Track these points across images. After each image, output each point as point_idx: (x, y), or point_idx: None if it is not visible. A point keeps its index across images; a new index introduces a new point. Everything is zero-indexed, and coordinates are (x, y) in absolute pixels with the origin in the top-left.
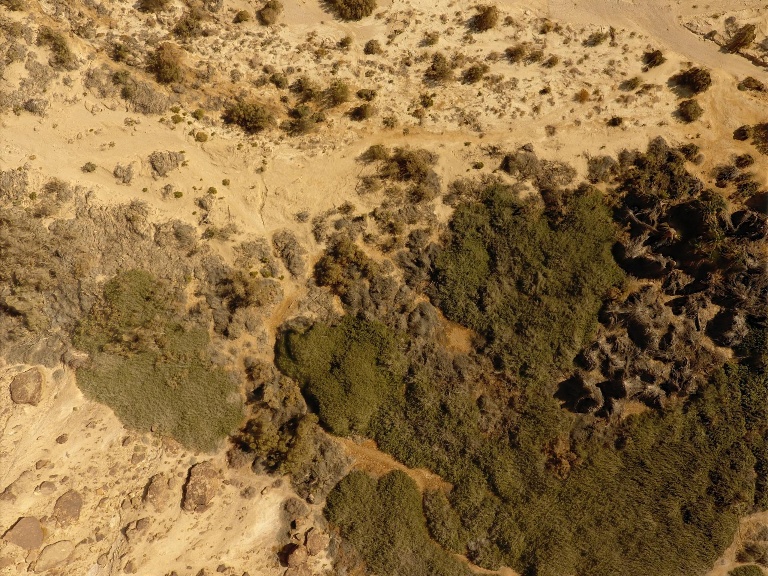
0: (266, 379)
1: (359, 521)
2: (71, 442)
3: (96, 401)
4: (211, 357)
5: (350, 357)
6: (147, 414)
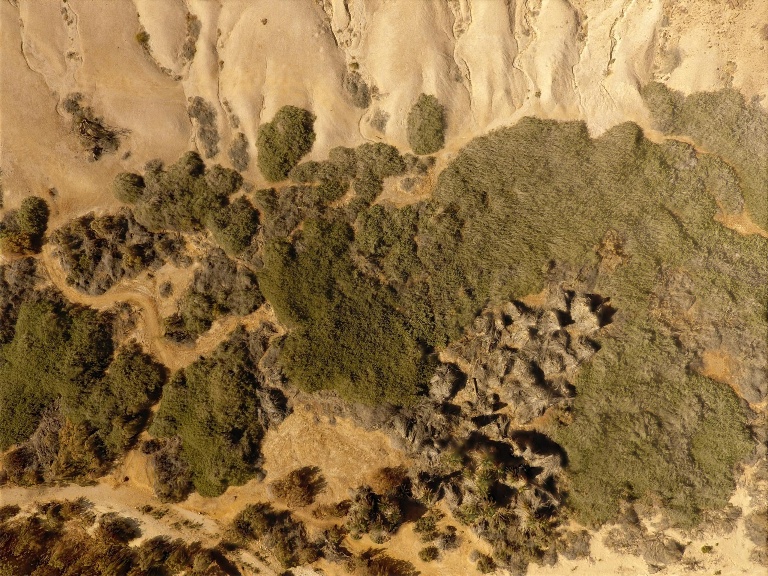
0: None
1: None
2: None
3: None
4: None
5: None
6: None
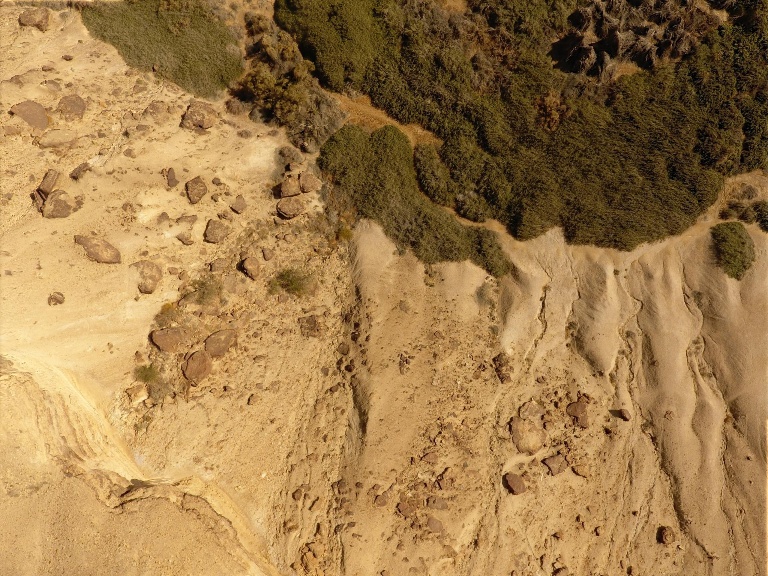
0: (265, 34)
1: (351, 167)
2: (76, 62)
3: (101, 40)
4: (212, 9)
5: (347, 3)
6: (149, 54)
